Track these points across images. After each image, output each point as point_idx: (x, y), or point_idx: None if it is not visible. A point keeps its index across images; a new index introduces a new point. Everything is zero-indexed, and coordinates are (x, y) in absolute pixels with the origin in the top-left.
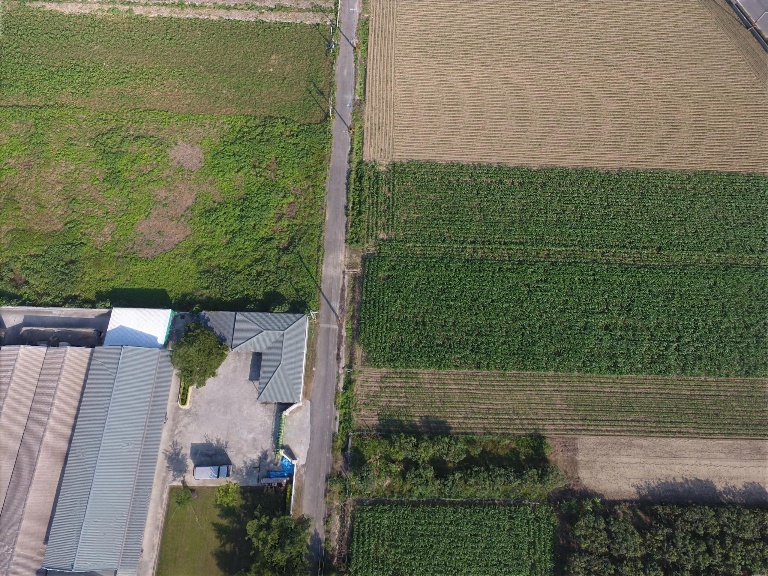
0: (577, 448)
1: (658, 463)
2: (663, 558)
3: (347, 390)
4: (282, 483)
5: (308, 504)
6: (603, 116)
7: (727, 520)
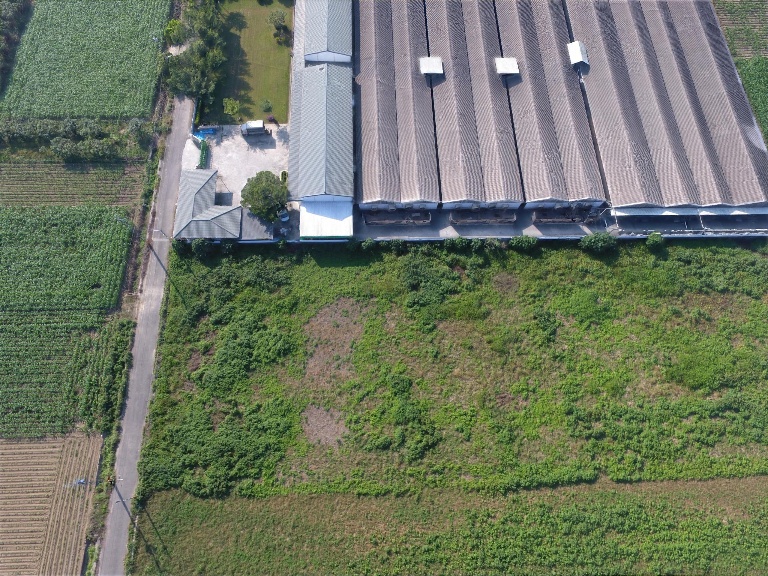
0: None
1: None
2: None
3: (148, 189)
4: None
5: (185, 117)
6: None
7: None
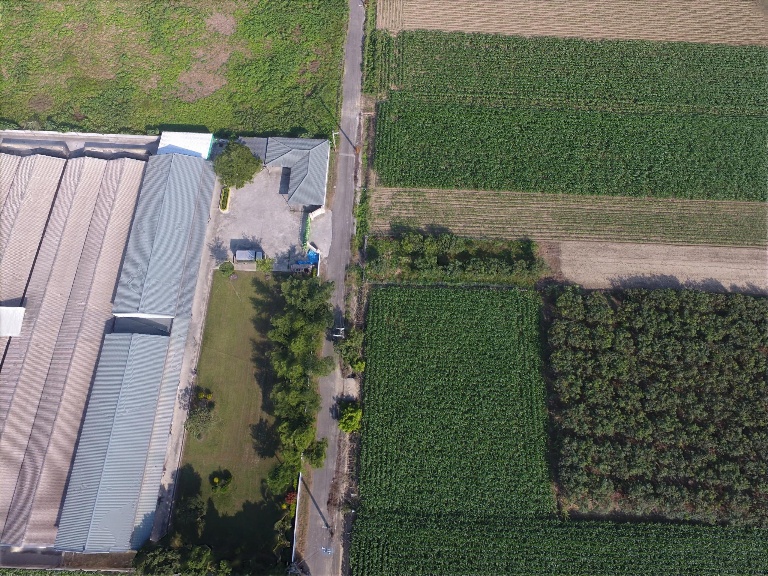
0: (560, 250)
1: (630, 262)
2: (631, 326)
3: (363, 203)
4: (308, 269)
5: None
6: None
7: (686, 296)
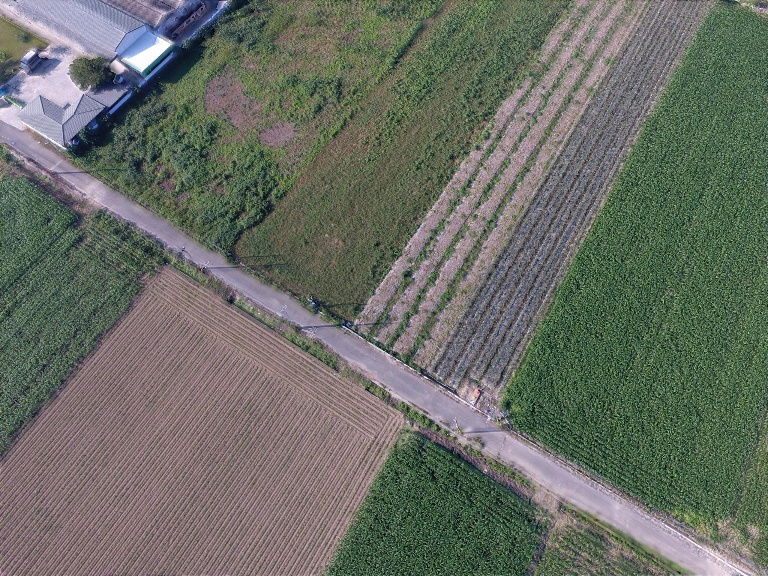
0: None
1: None
2: None
3: (6, 155)
4: None
5: None
6: (5, 572)
7: None
